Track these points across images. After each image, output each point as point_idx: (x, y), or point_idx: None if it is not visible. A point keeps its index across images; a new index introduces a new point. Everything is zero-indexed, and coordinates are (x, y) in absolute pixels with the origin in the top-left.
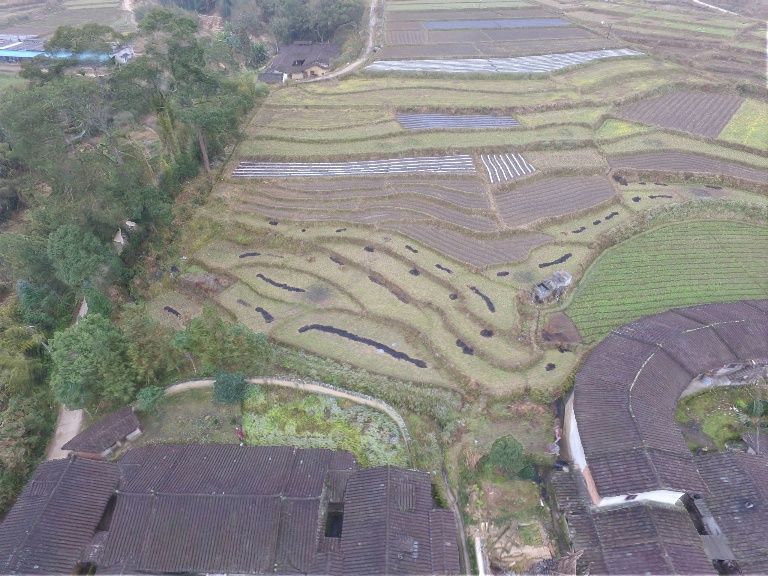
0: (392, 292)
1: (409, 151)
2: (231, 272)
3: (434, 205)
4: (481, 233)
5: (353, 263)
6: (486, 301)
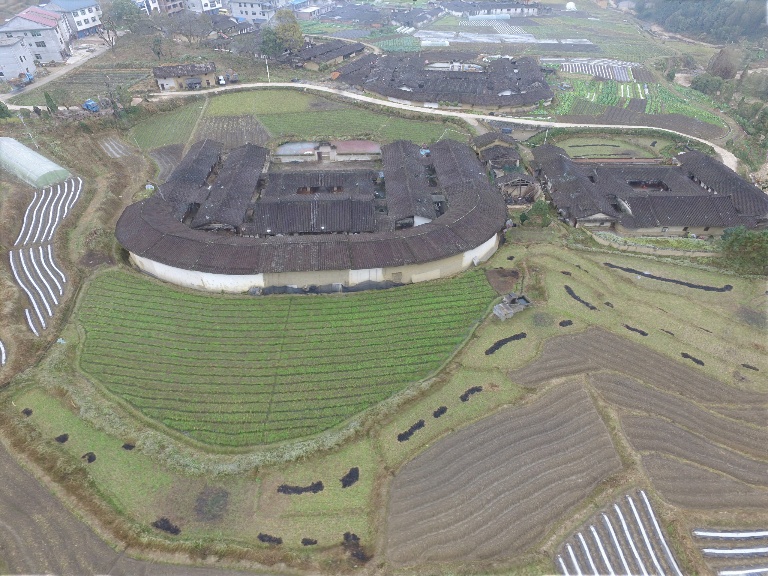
0: None
1: None
2: None
3: (719, 437)
4: None
5: None
6: (575, 295)
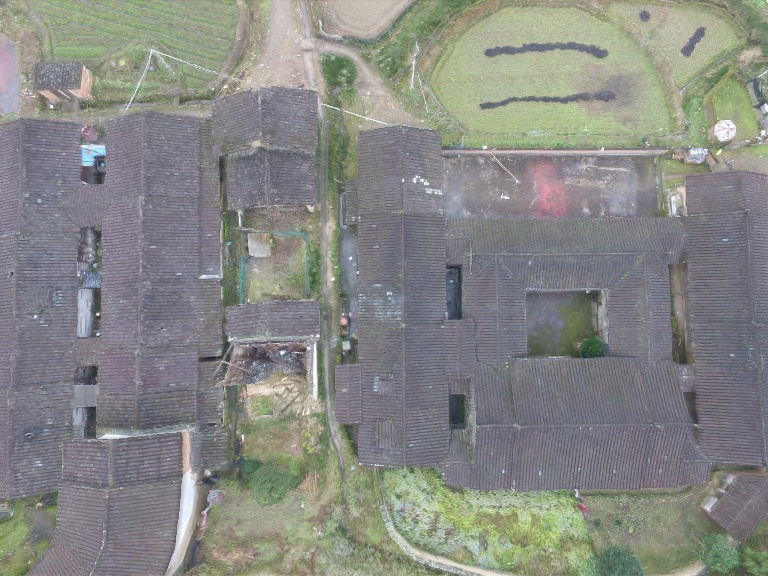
0: None
1: None
2: None
3: None
4: None
5: None
6: None
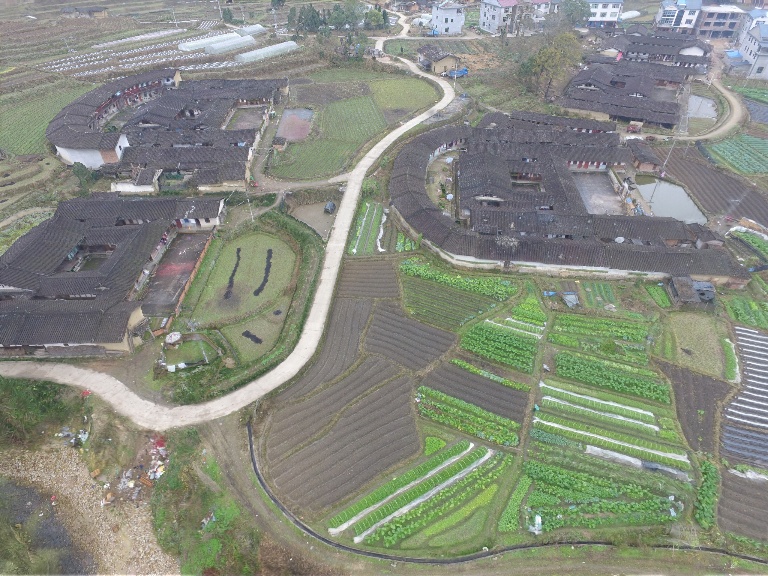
0: None
1: None
2: None
3: None
4: None
5: None
6: None
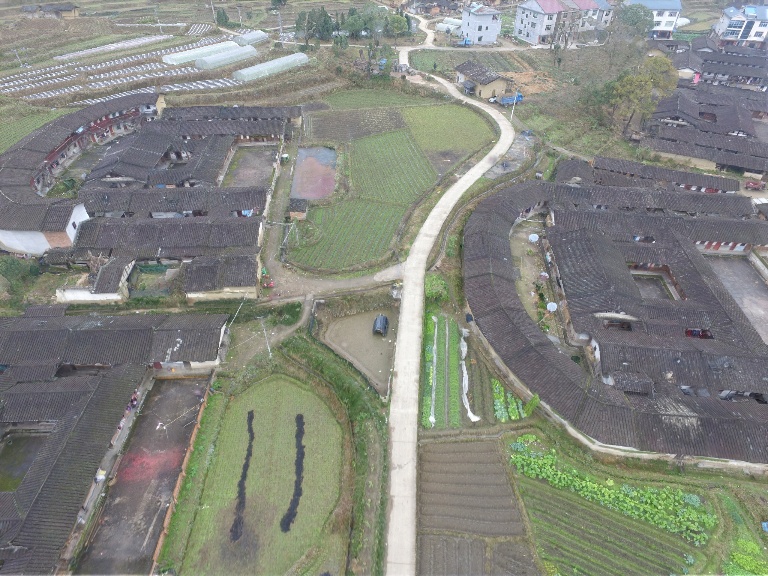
0: None
1: None
2: None
3: None
4: None
5: None
6: None
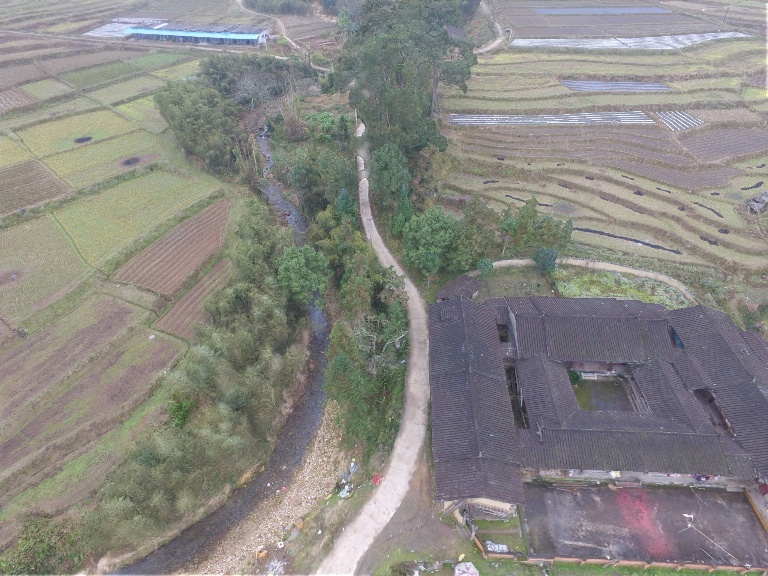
0: (626, 207)
1: (591, 107)
2: (483, 193)
3: (631, 147)
4: (684, 166)
5: (583, 187)
6: (712, 211)
